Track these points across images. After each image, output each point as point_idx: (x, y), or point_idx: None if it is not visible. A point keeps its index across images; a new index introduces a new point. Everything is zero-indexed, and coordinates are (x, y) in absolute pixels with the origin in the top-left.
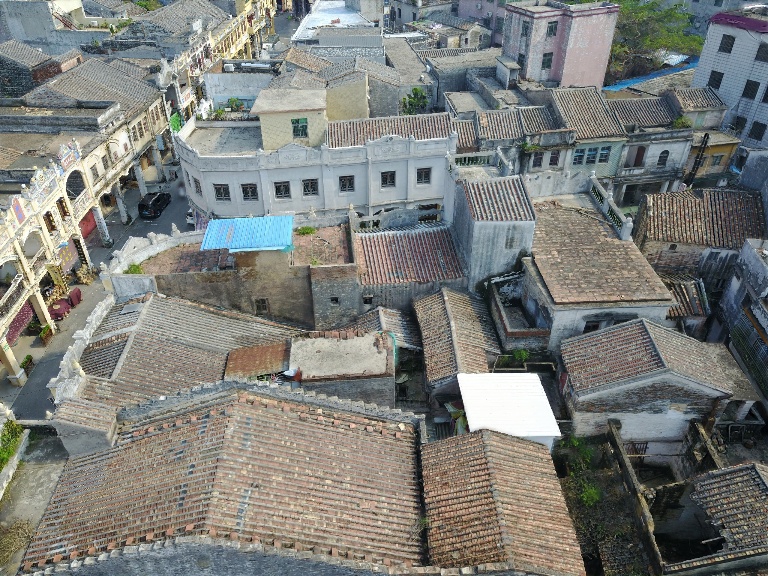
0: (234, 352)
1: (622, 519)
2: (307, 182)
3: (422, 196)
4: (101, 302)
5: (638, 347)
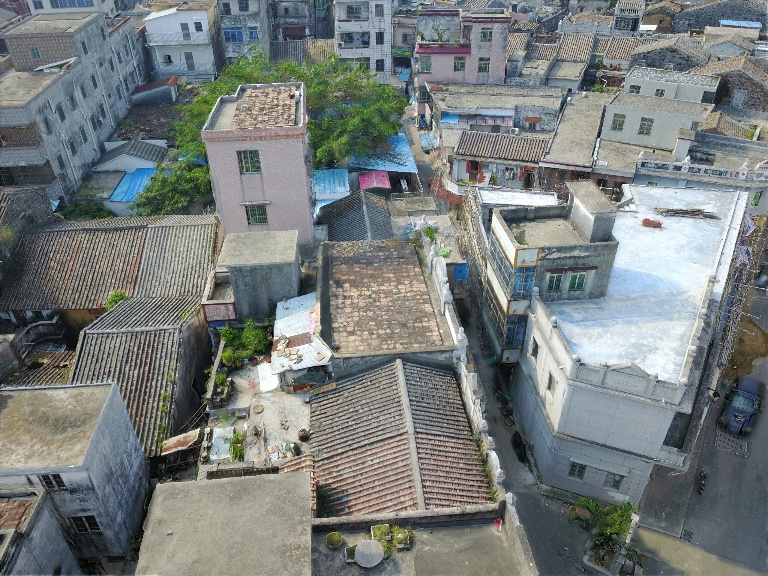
0: None
1: None
2: None
3: None
4: None
5: None
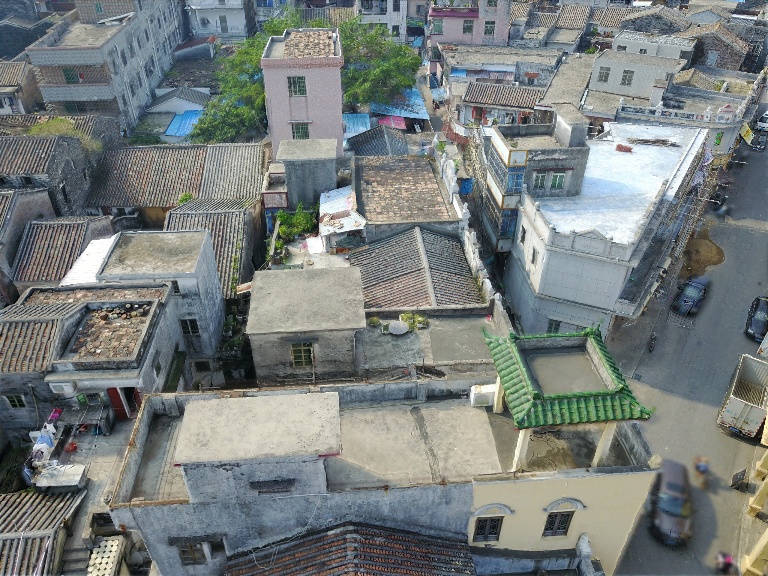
0: None
1: None
2: None
3: None
4: None
5: None
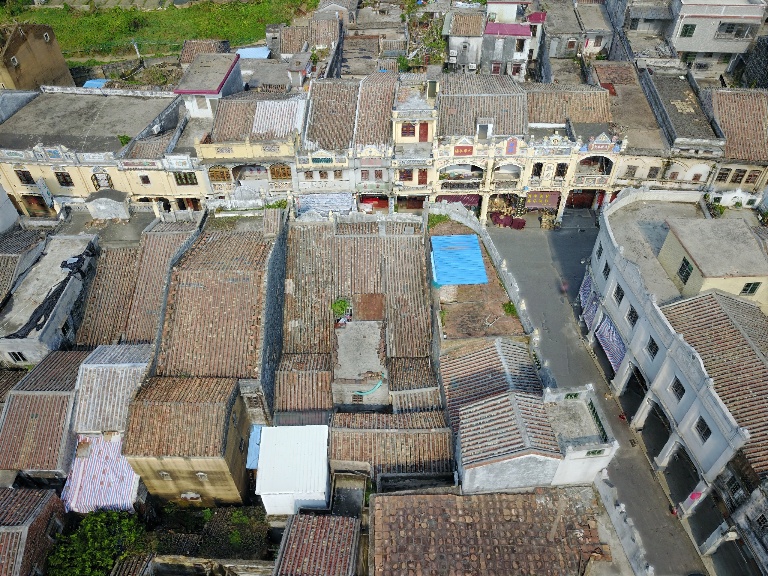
0: (381, 296)
1: (212, 558)
2: (634, 310)
3: (691, 444)
4: (410, 214)
5: (315, 569)
